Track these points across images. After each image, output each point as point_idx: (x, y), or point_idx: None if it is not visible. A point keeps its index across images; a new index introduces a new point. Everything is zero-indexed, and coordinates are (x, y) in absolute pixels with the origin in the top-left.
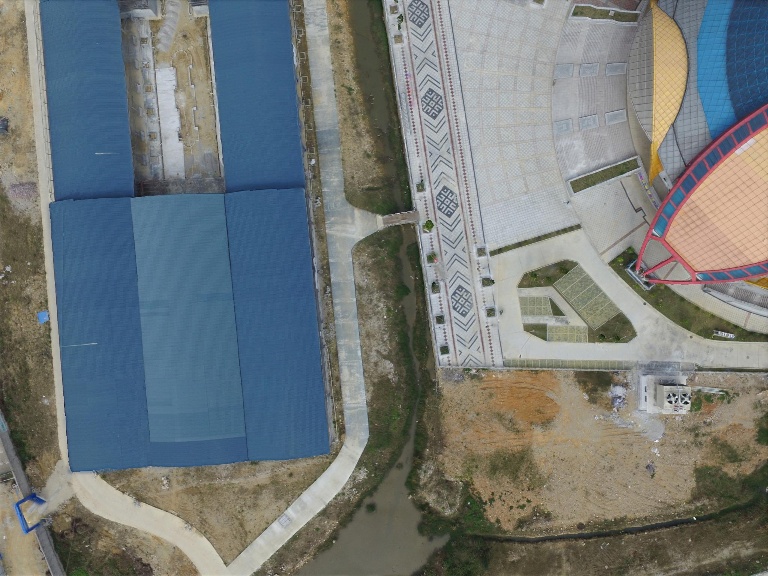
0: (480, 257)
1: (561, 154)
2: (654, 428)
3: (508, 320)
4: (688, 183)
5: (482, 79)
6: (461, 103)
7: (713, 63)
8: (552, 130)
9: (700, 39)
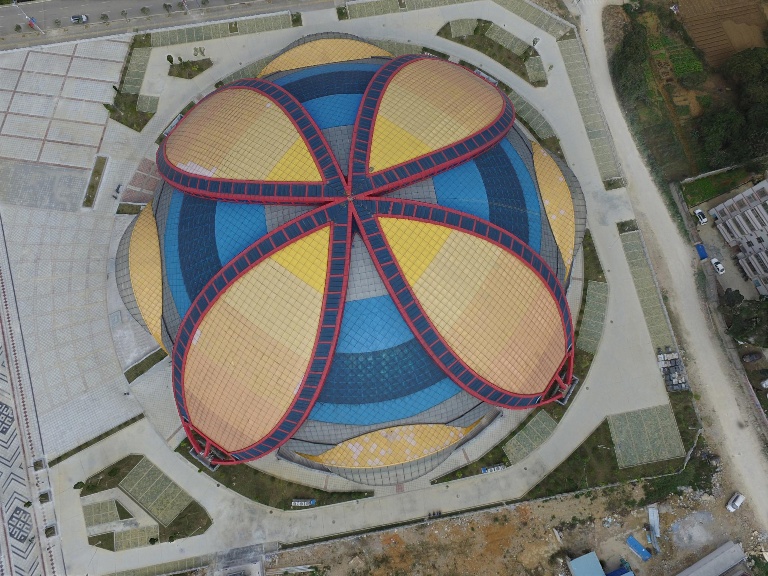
0: (38, 471)
1: (118, 345)
2: None
3: (72, 536)
4: (177, 373)
5: (36, 286)
6: (15, 314)
7: (172, 258)
8: (109, 323)
9: (165, 236)
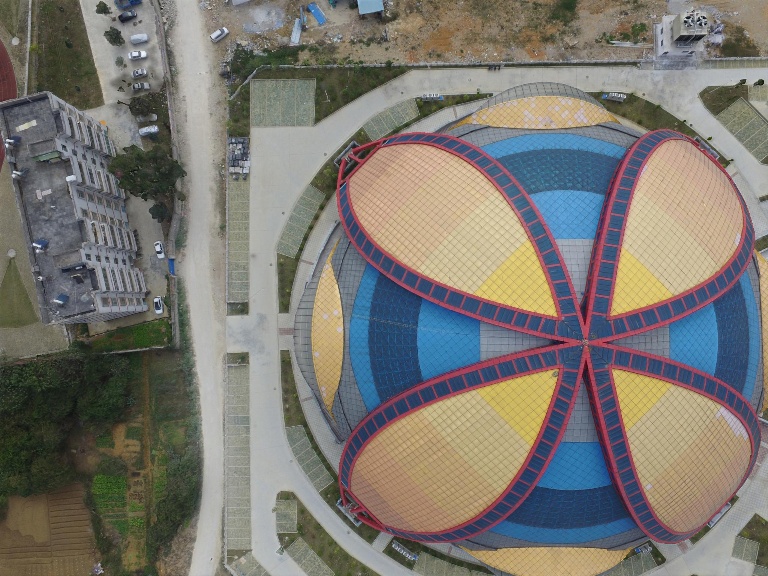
0: None
1: None
2: (678, 6)
3: None
4: None
5: None
6: None
7: None
8: None
9: None
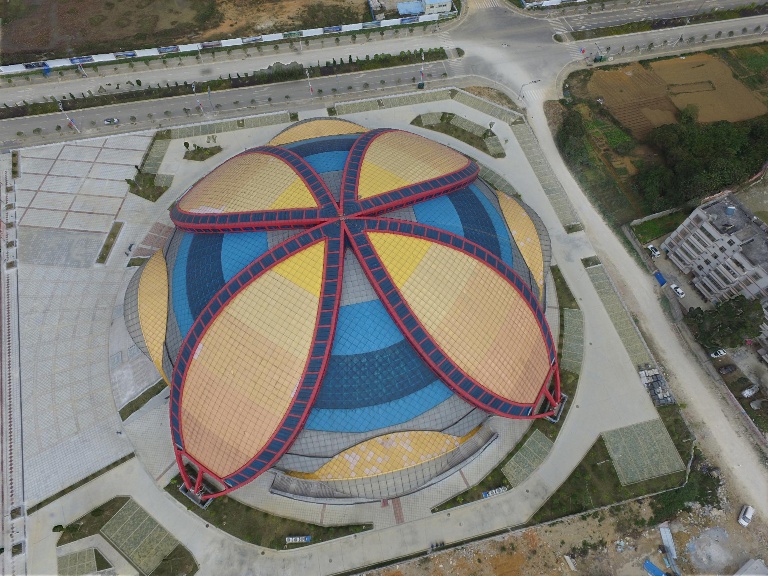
0: (15, 520)
1: (115, 386)
2: None
3: None
4: (175, 393)
5: (41, 334)
6: (17, 360)
7: (180, 287)
8: (108, 365)
9: (174, 270)
